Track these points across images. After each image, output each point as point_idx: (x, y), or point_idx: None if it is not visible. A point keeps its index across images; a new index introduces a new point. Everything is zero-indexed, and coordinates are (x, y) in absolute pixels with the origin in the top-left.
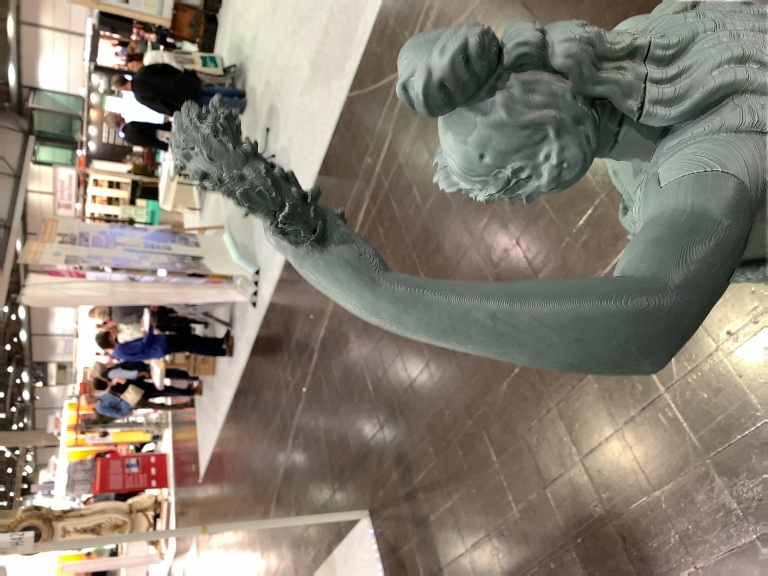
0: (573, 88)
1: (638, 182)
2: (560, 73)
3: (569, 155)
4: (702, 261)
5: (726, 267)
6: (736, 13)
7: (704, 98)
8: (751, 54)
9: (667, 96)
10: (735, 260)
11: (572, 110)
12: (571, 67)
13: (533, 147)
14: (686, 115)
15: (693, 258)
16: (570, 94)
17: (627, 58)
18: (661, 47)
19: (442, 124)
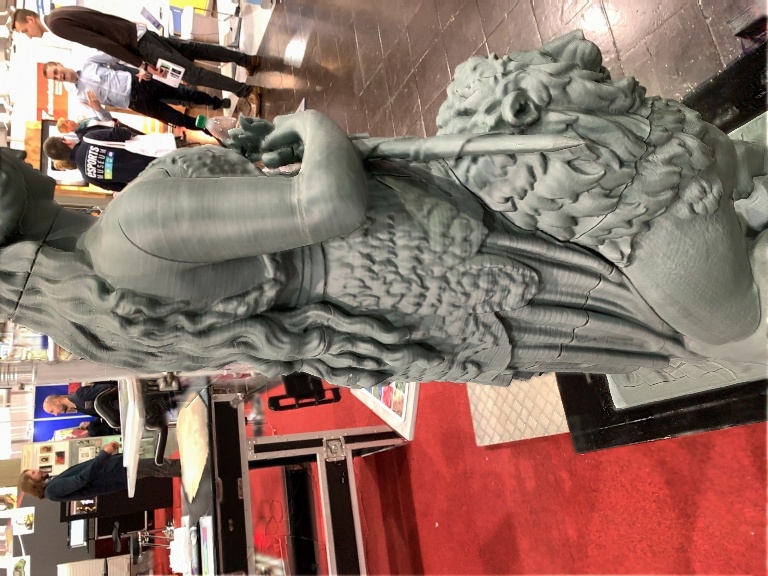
0: None
1: None
2: None
3: None
4: None
5: None
6: (97, 352)
7: None
8: None
9: None
10: None
11: None
12: None
13: None
14: None
15: None
16: None
17: None
18: None
19: None
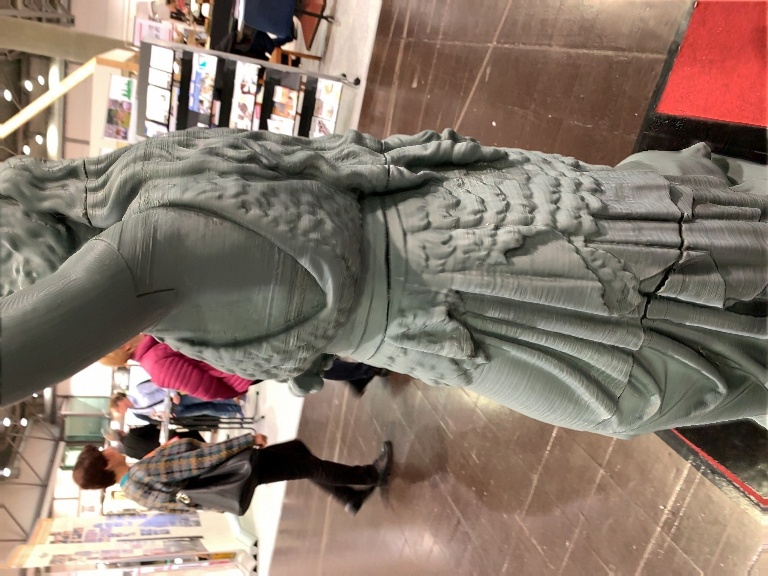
0: (24, 208)
1: None
2: (9, 197)
3: (35, 265)
4: (21, 309)
5: (57, 314)
6: None
7: (118, 192)
8: (151, 152)
9: (99, 198)
10: (85, 310)
11: (24, 225)
12: (9, 189)
13: (5, 264)
14: (116, 210)
15: (11, 308)
16: (21, 213)
17: (70, 177)
18: (93, 163)
19: None
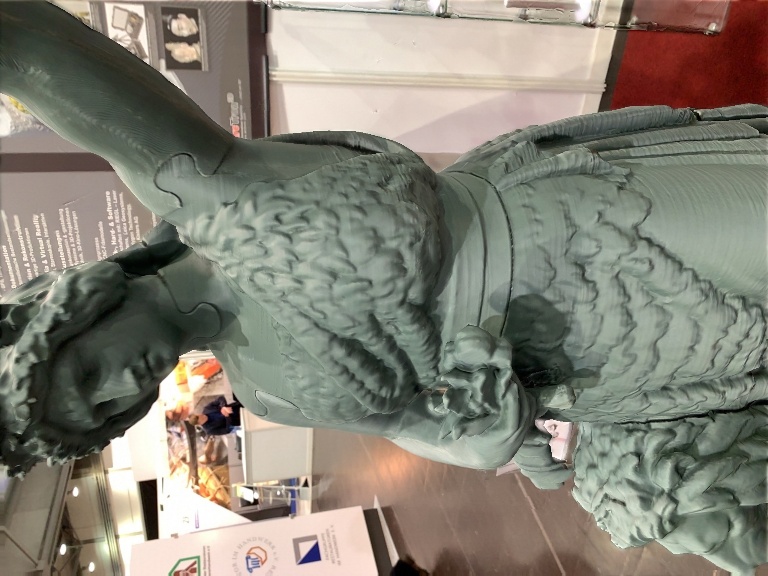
0: None
1: None
2: None
3: None
4: None
5: None
6: None
7: None
8: None
9: None
10: None
11: None
12: None
13: (42, 289)
14: None
15: None
16: None
17: None
18: None
19: None
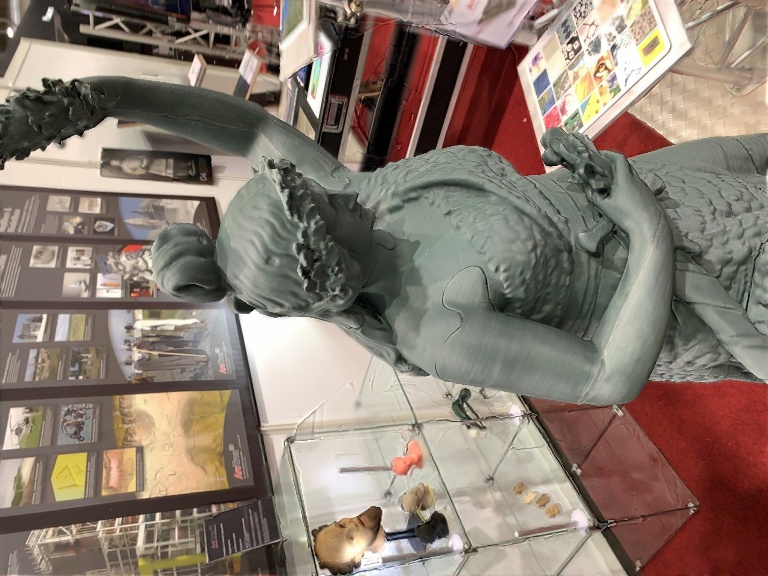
0: None
1: (396, 215)
2: None
3: None
4: None
5: None
6: None
7: None
8: None
9: None
10: None
11: None
12: None
13: None
14: None
15: None
16: None
17: None
18: None
19: (223, 224)
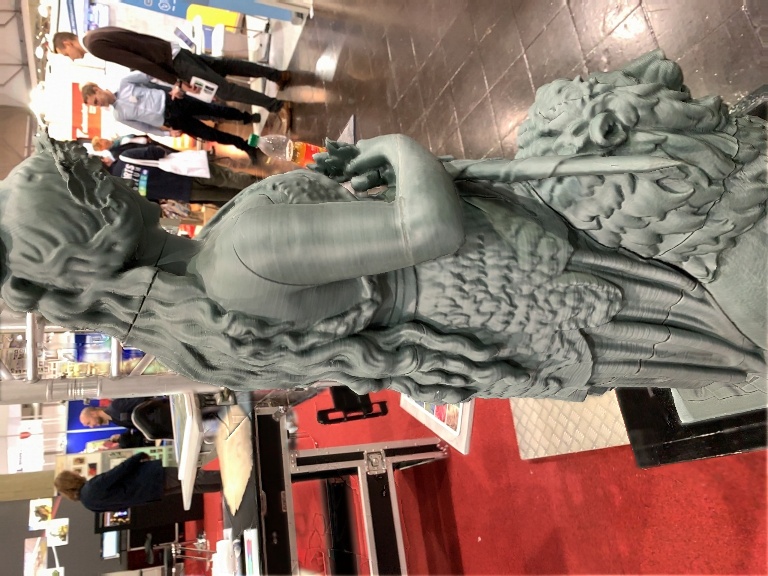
0: None
1: None
2: None
3: None
4: None
5: None
6: (202, 371)
7: None
8: None
9: None
10: None
11: None
12: None
13: None
14: None
15: None
16: None
17: None
18: None
19: None
